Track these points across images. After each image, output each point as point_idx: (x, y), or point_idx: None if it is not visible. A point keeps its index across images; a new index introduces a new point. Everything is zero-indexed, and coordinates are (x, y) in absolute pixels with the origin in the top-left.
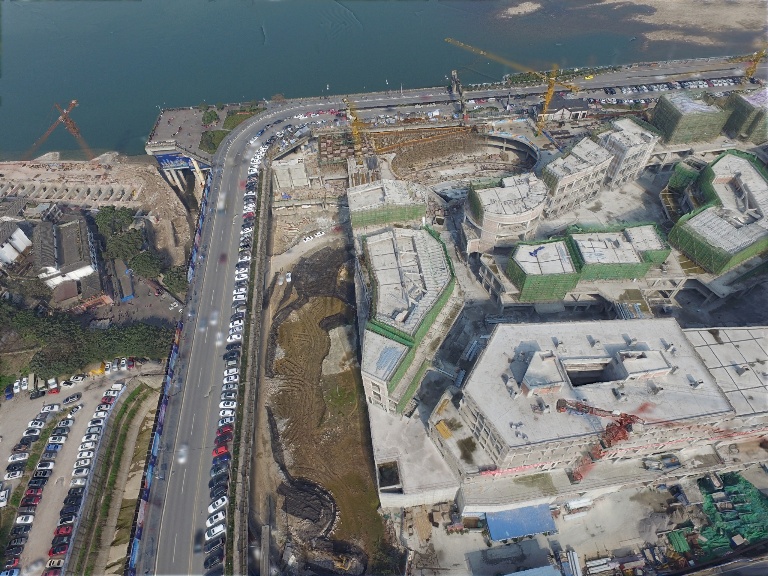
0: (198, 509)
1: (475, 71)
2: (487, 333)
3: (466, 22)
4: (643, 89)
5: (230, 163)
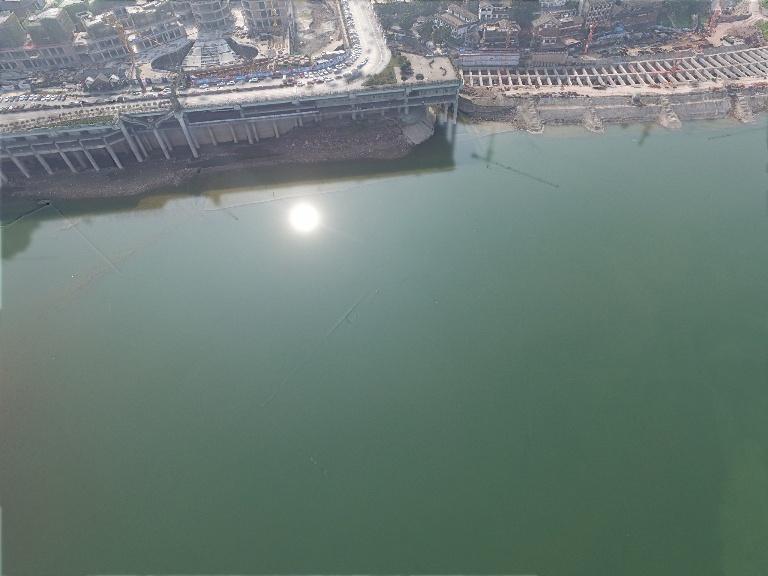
0: None
1: (105, 257)
2: (236, 2)
3: (8, 432)
4: (4, 107)
5: (376, 51)
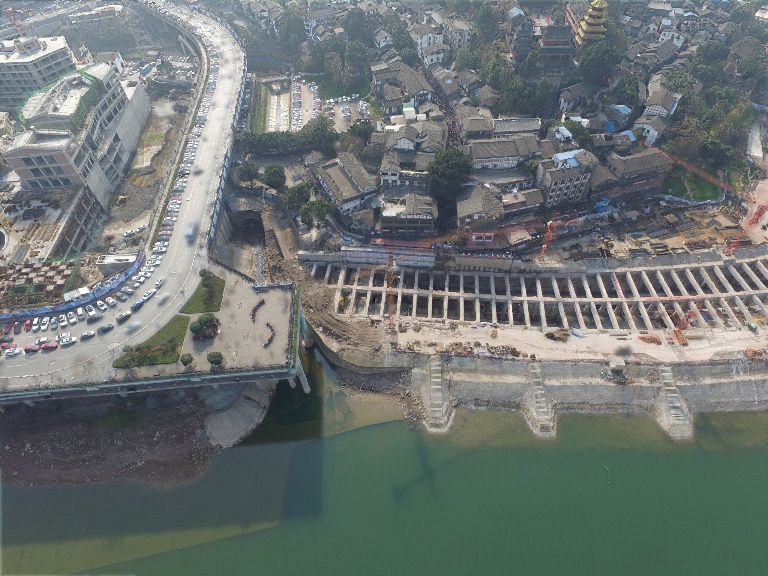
0: (221, 81)
1: None
2: None
3: None
4: None
5: (187, 259)
